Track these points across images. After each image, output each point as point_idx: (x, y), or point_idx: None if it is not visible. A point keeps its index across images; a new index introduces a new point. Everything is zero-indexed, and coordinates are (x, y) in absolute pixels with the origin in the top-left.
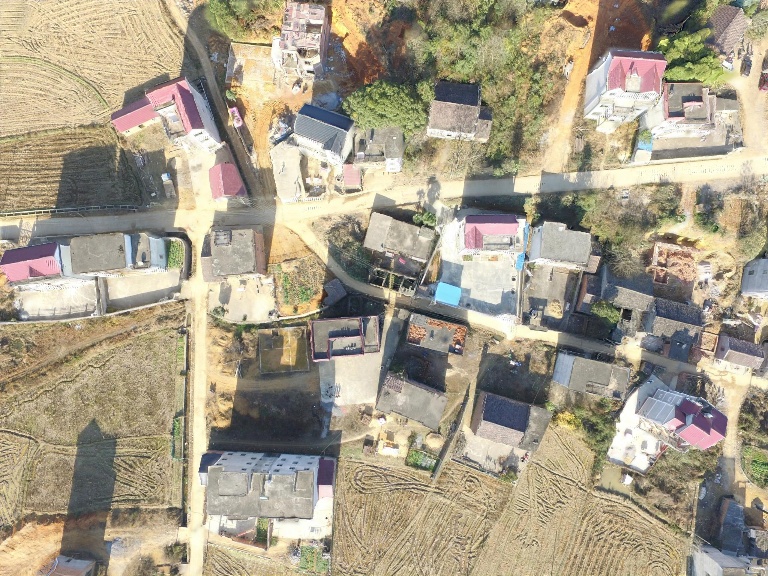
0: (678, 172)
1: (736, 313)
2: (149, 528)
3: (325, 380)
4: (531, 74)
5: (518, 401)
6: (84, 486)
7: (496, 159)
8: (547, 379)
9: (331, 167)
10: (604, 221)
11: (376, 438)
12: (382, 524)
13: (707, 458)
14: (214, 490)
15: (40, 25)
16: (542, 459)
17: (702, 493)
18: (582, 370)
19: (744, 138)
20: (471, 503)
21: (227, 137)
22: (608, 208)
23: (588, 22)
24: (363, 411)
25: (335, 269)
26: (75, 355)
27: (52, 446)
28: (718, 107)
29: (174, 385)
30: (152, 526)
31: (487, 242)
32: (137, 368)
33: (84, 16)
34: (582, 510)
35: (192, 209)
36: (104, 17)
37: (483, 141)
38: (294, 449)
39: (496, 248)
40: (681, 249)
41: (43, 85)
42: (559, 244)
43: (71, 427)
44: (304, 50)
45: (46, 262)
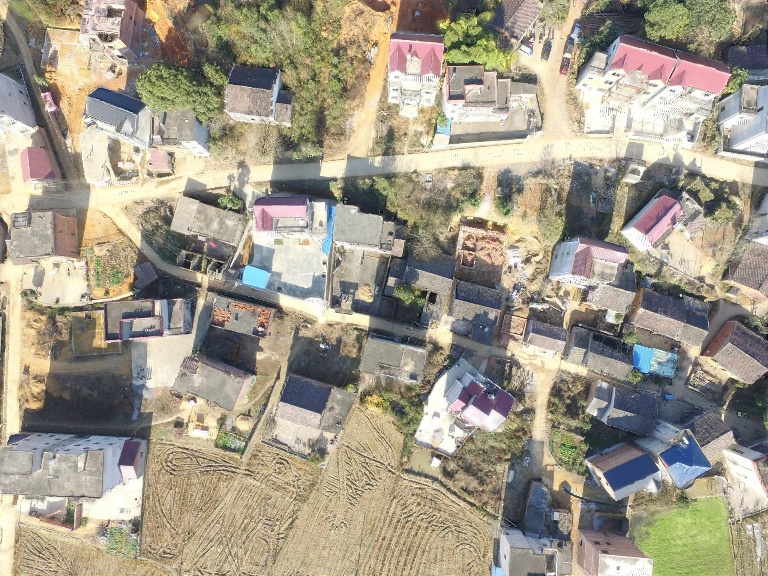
0: (480, 156)
1: (544, 297)
2: None
3: (137, 363)
4: (331, 58)
5: (326, 384)
6: None
7: (299, 143)
8: (358, 362)
9: (143, 151)
10: (407, 205)
11: (186, 420)
12: (192, 505)
13: (512, 441)
14: None
15: None
16: (352, 442)
17: (510, 476)
18: (373, 352)
19: (545, 122)
20: (280, 485)
21: (44, 122)
22: (412, 192)
23: (390, 7)
24: (174, 393)
25: (148, 253)
26: None
27: None
28: (515, 91)
29: None
30: None
31: (284, 225)
32: None
33: None
34: (391, 492)
35: (8, 193)
36: None
37: (288, 125)
38: (105, 431)
39: (292, 231)
40: (486, 233)
41: None
42: (351, 226)
43: None
44: (105, 34)
45: None
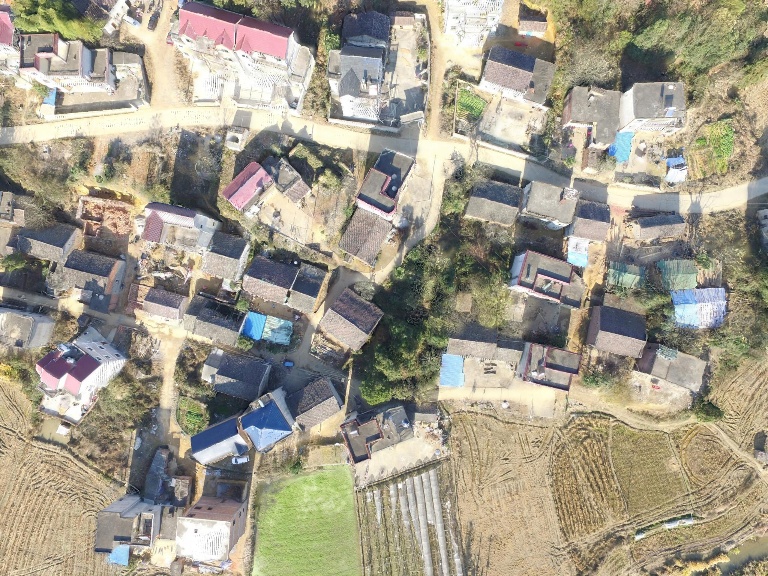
0: (93, 126)
1: (168, 266)
2: None
3: None
4: None
5: None
6: None
7: None
8: None
9: None
10: None
11: None
12: None
13: (133, 408)
14: None
15: None
16: None
17: (136, 443)
18: None
19: (154, 92)
20: None
21: None
22: (29, 162)
23: None
24: None
25: None
26: None
27: None
28: (117, 61)
29: None
30: None
31: None
32: None
33: None
34: (20, 460)
35: None
36: None
37: None
38: None
39: None
40: (104, 202)
41: None
42: None
43: None
44: None
45: None
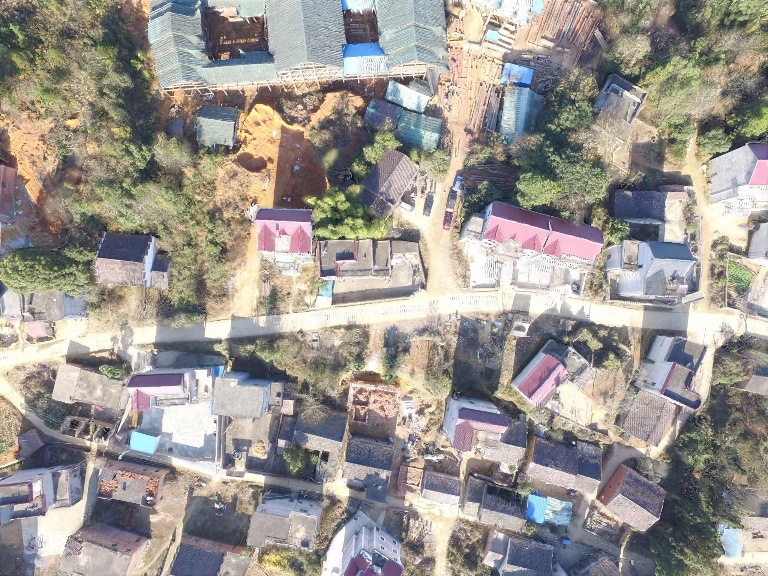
0: (366, 314)
1: (439, 447)
2: None
3: (27, 531)
4: (207, 221)
5: (222, 545)
6: None
7: (180, 307)
8: None
9: None
10: (294, 365)
11: None
12: None
13: None
14: None
15: None
16: None
17: None
18: (260, 525)
19: (430, 277)
20: None
21: None
22: (298, 351)
23: (267, 164)
24: None
25: (33, 418)
26: None
27: None
28: (396, 250)
29: None
30: None
31: (164, 397)
32: None
33: None
34: None
35: None
36: None
37: None
38: None
39: (172, 404)
40: None
41: None
42: (231, 400)
43: None
44: None
45: None
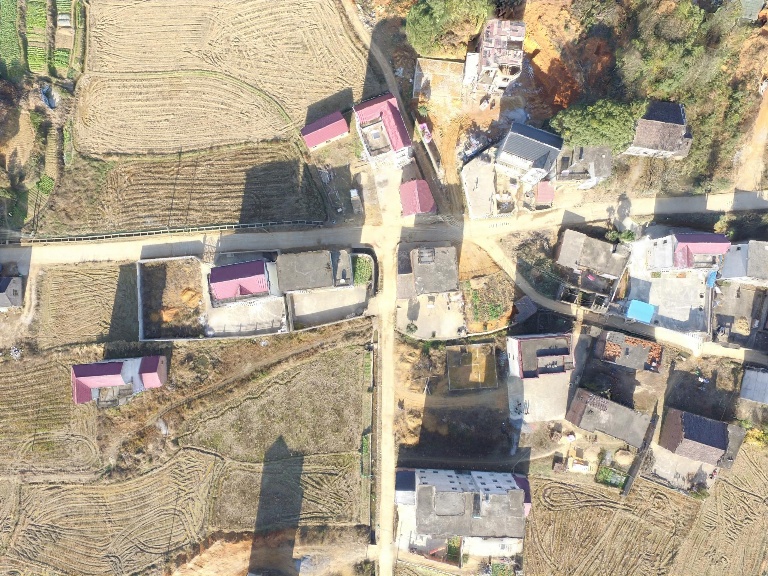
0: None
1: None
2: (338, 546)
3: (513, 397)
4: (730, 92)
5: None
6: (271, 503)
7: (692, 177)
8: (734, 396)
9: (520, 183)
10: None
11: (565, 455)
12: (571, 541)
13: None
14: (424, 509)
15: (220, 39)
16: (729, 476)
17: None
18: None
19: None
20: (660, 520)
21: (412, 153)
22: None
23: None
24: (552, 428)
25: (523, 286)
26: (262, 372)
27: (238, 463)
28: None
29: (361, 402)
30: (341, 544)
31: None
32: (323, 385)
33: (265, 30)
34: None
35: (379, 225)
36: (285, 31)
37: (678, 159)
38: (483, 466)
39: (700, 266)
40: None
41: (224, 99)
42: (766, 263)
43: (258, 444)
44: (505, 67)
45: (256, 280)
